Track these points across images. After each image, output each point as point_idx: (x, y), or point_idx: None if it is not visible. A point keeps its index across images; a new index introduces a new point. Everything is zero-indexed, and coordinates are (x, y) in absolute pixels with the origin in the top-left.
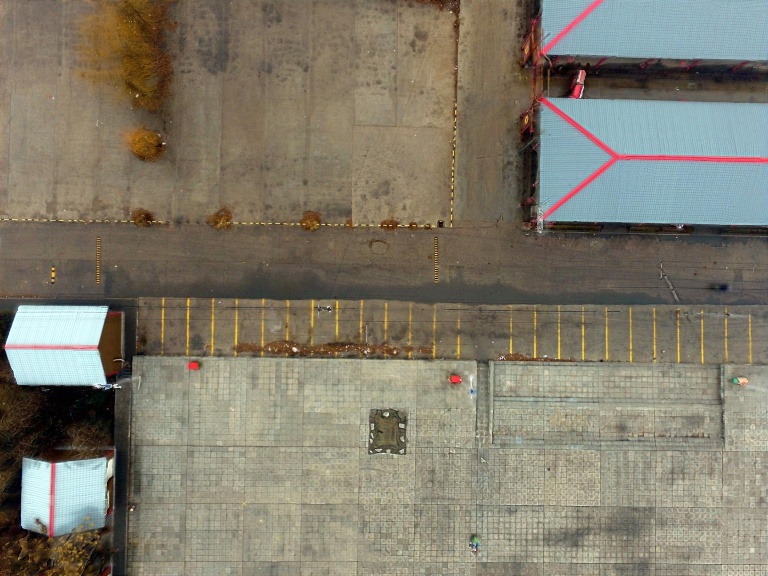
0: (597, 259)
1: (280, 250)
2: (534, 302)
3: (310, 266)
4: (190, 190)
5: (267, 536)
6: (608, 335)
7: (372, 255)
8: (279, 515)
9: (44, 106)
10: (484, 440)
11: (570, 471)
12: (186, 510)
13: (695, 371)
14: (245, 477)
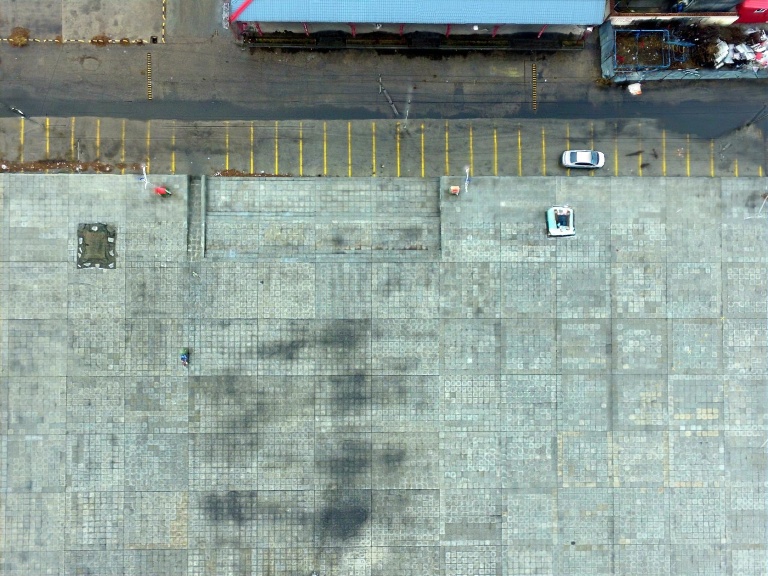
0: (314, 73)
1: None
2: (251, 118)
3: (19, 83)
4: None
5: None
6: (326, 150)
7: (83, 71)
8: None
9: None
10: (196, 254)
11: (284, 284)
12: None
13: (414, 184)
14: None
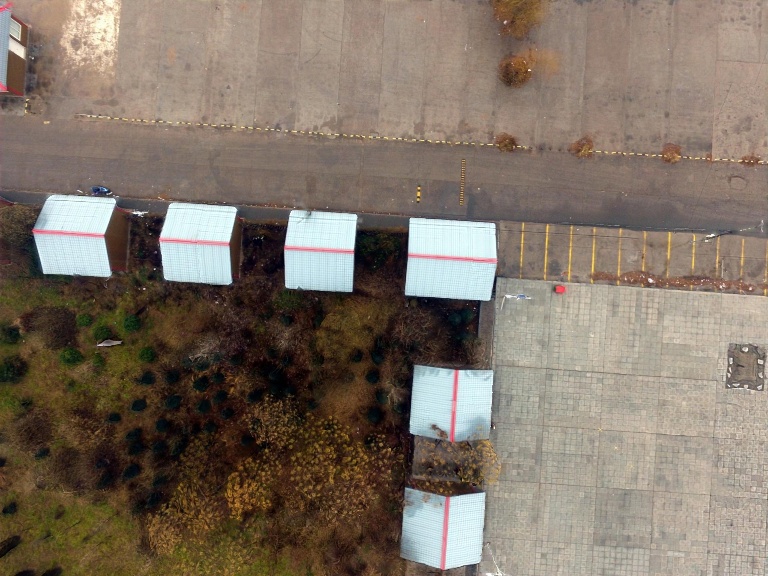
0: None
1: (639, 181)
2: None
3: (668, 198)
4: (553, 117)
5: (621, 463)
6: None
7: (731, 190)
8: (634, 443)
9: (416, 29)
10: None
11: None
12: (543, 432)
13: None
14: (602, 403)
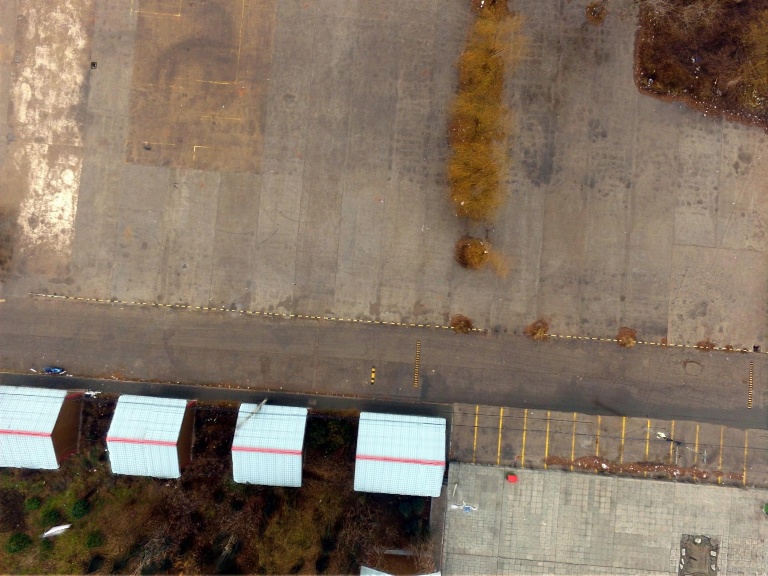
0: None
1: (594, 365)
2: None
3: (623, 383)
4: (509, 299)
5: None
6: None
7: (686, 376)
8: None
9: (373, 209)
10: None
11: None
12: None
13: None
14: None
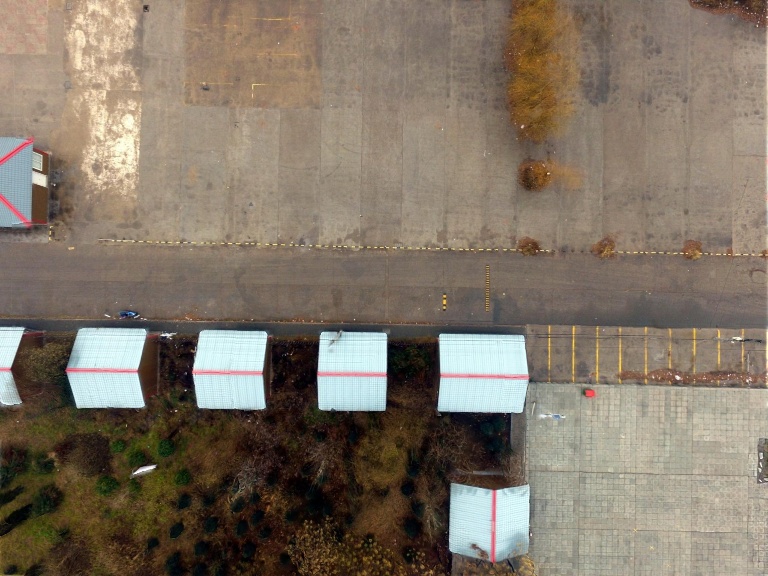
0: None
1: (662, 279)
2: None
3: (692, 295)
4: (574, 219)
5: (658, 563)
6: None
7: (753, 284)
8: (669, 542)
9: (434, 137)
10: None
11: None
12: (579, 535)
13: None
14: (636, 504)
